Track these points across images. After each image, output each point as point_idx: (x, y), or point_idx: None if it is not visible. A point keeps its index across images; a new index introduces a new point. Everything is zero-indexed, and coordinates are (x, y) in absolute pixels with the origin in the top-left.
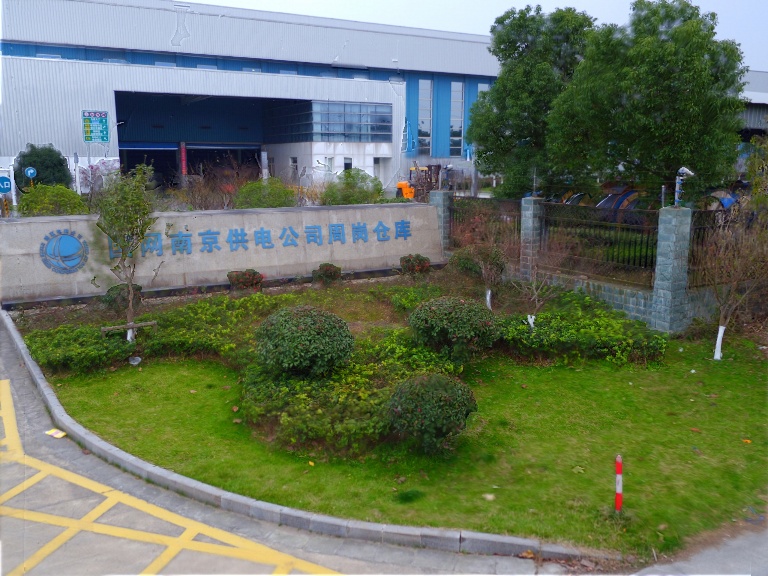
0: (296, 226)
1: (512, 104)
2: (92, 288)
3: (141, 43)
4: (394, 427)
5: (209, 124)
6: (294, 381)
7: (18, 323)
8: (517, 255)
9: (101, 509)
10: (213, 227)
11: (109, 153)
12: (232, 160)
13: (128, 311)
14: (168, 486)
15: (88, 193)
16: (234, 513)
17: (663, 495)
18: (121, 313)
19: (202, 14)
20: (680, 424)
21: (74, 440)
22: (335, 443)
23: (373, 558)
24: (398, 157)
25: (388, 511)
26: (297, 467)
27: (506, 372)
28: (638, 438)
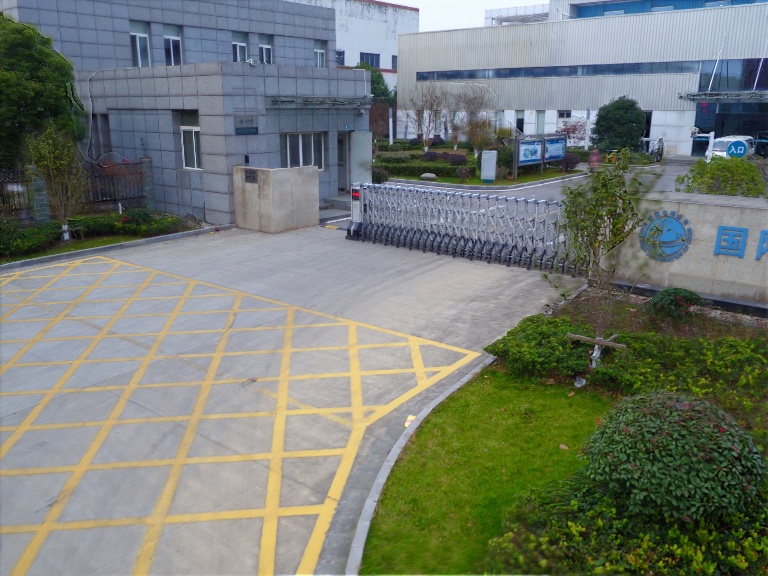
0: None
1: None
2: (684, 284)
3: None
4: None
5: None
6: (609, 502)
7: None
8: None
9: (300, 510)
10: None
11: None
12: None
13: None
14: None
15: None
16: None
17: None
18: (657, 322)
19: None
20: None
21: None
22: None
23: None
24: None
25: None
26: None
27: None
28: None
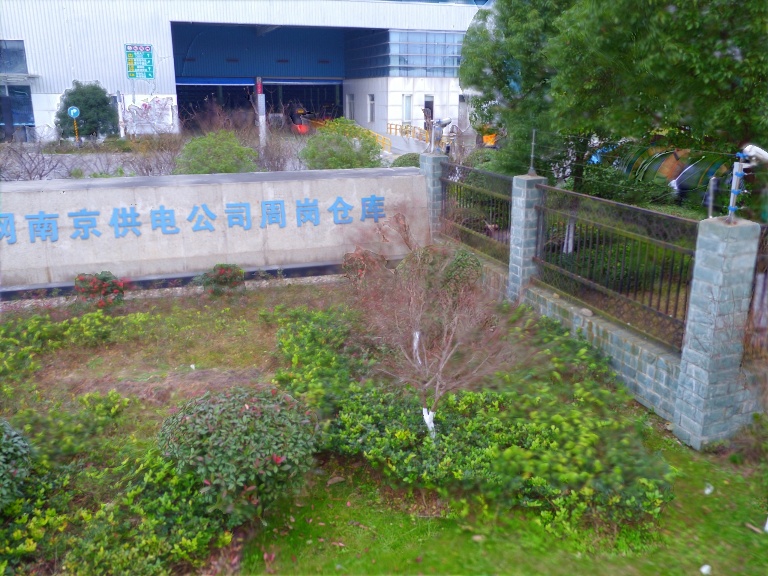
0: (213, 203)
1: (515, 28)
2: None
3: None
4: None
5: None
6: None
7: None
8: (508, 260)
9: None
10: (90, 205)
11: (166, 90)
12: (215, 105)
13: None
14: None
15: None
16: None
17: None
18: None
19: None
20: None
21: None
22: None
23: None
24: None
25: None
26: None
27: (340, 530)
28: None
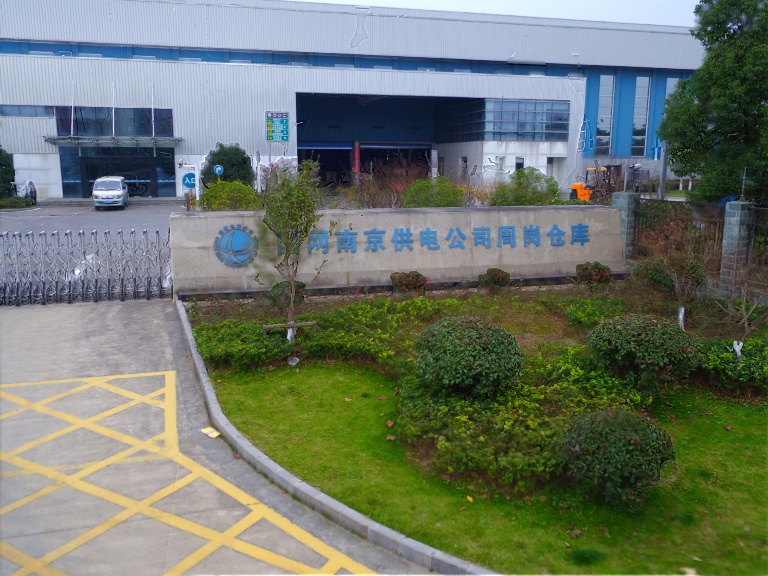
0: (464, 227)
1: (719, 94)
2: None
3: (323, 46)
4: (569, 467)
5: (382, 124)
6: (454, 399)
7: (190, 314)
8: (716, 268)
9: (244, 524)
10: (379, 226)
11: (288, 152)
12: (402, 158)
13: (289, 310)
14: (314, 506)
15: None
16: (381, 548)
17: None
18: (284, 310)
19: (381, 16)
20: None
21: (227, 442)
22: (498, 478)
23: None
24: (574, 157)
25: (559, 573)
26: (453, 501)
27: (705, 408)
28: None
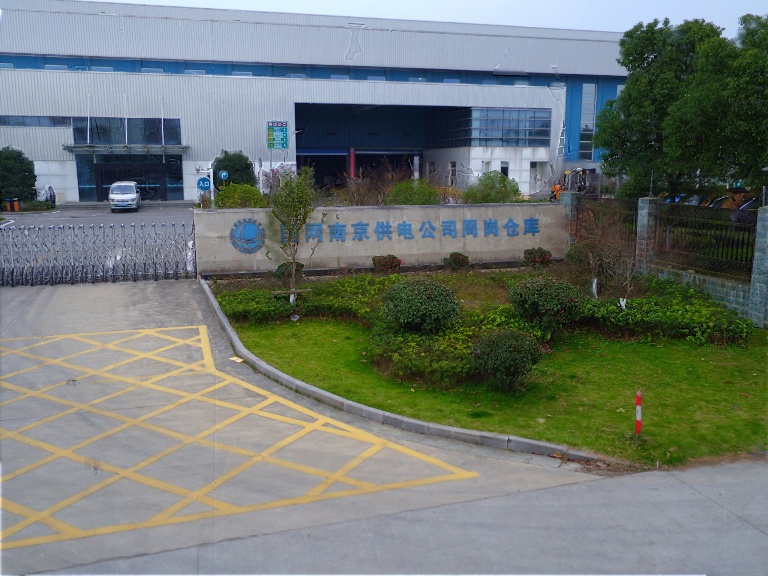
0: (434, 221)
1: (636, 111)
2: (267, 266)
3: (320, 59)
4: (477, 368)
5: (376, 131)
6: (409, 334)
7: (213, 289)
8: (634, 251)
9: (264, 404)
10: (364, 220)
11: (288, 158)
12: (388, 164)
13: (291, 280)
14: (309, 395)
15: None
16: (352, 414)
17: (685, 431)
18: (287, 284)
19: (374, 29)
20: (732, 390)
21: (249, 364)
22: (431, 377)
23: (443, 446)
24: (555, 161)
25: (461, 421)
26: (401, 391)
27: (592, 344)
28: (686, 396)
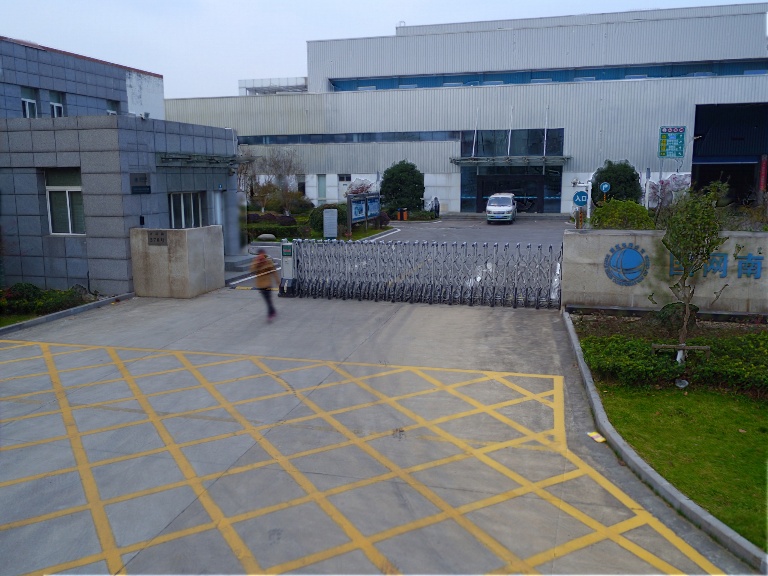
0: None
1: None
2: (648, 302)
3: (732, 52)
4: None
5: None
6: None
7: (577, 326)
8: None
9: (629, 524)
10: None
11: (681, 168)
12: None
13: (681, 331)
14: (701, 525)
15: (655, 208)
16: None
17: None
18: (673, 332)
19: None
20: None
21: (612, 448)
22: None
23: None
24: None
25: None
26: None
27: None
28: None
